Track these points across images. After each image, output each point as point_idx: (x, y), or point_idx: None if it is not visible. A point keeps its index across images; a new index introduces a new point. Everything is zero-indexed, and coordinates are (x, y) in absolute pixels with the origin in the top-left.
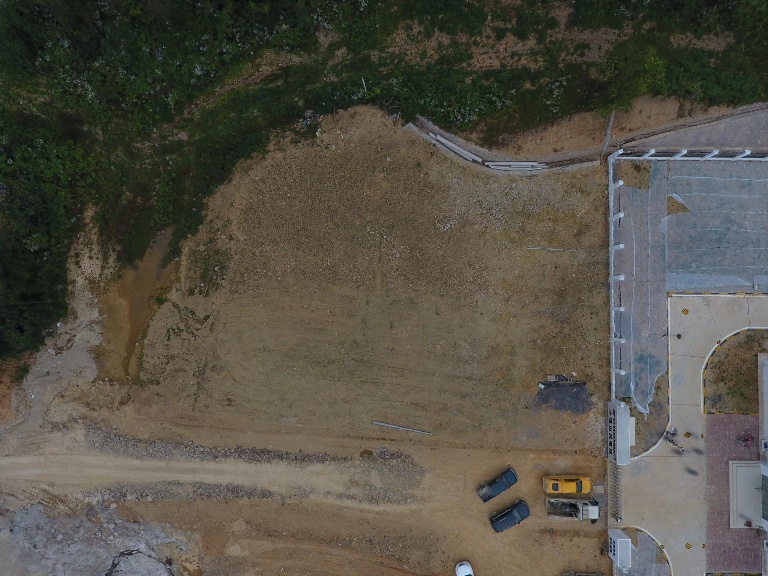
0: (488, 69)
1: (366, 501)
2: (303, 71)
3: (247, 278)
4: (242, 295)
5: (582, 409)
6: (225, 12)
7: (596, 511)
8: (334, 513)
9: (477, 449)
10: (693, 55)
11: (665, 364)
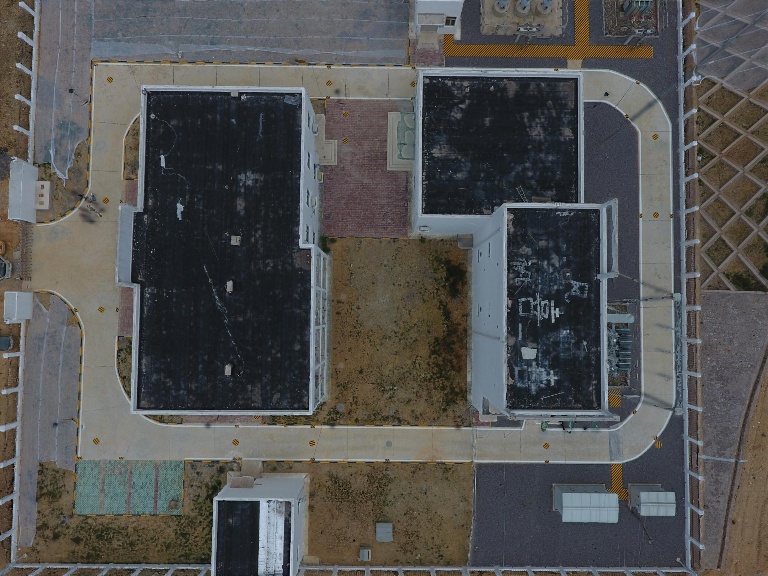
0: None
1: None
2: None
3: None
4: None
5: None
6: None
7: None
8: None
9: None
10: None
11: (86, 131)
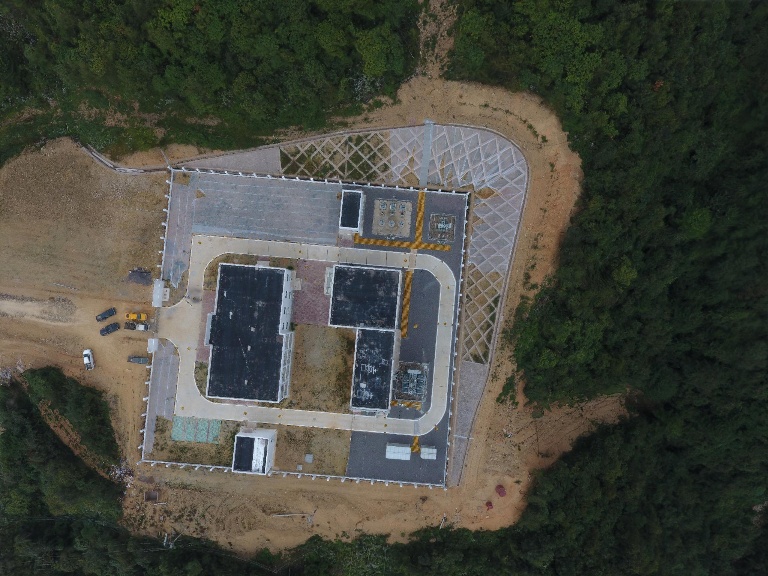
0: (111, 126)
1: (49, 320)
2: (42, 118)
3: (4, 213)
4: (1, 221)
5: (146, 283)
6: (2, 89)
7: (142, 327)
8: (34, 325)
9: (101, 299)
10: (197, 127)
11: (187, 266)
